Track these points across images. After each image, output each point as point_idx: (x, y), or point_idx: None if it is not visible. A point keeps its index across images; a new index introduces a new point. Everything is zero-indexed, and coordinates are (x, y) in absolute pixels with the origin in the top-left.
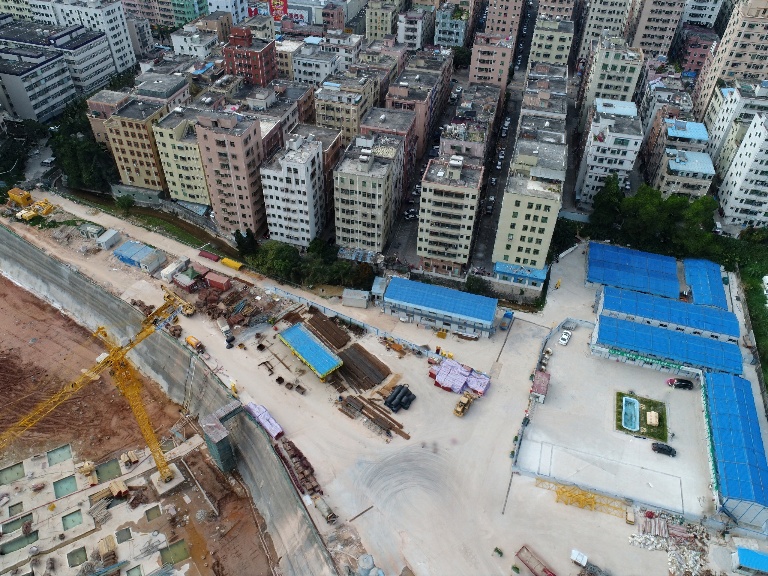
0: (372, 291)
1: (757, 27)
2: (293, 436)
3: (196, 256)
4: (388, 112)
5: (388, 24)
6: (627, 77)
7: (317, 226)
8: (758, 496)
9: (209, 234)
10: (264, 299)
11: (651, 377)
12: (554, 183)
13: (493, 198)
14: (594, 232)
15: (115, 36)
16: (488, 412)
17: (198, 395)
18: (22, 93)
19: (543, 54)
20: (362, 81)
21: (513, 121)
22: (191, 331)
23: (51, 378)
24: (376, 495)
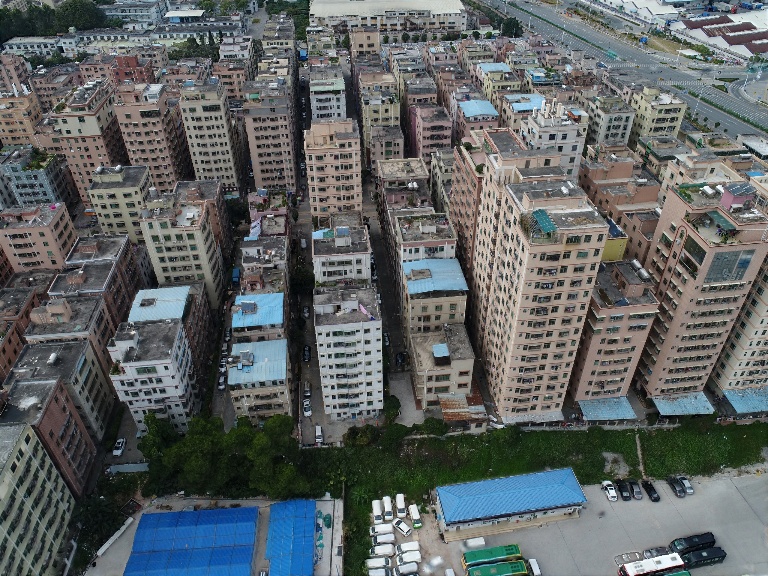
0: None
1: (326, 158)
2: None
3: None
4: None
5: None
6: (189, 245)
7: None
8: None
9: None
10: None
11: None
12: None
13: None
14: (157, 489)
15: None
16: None
17: None
18: None
19: (113, 214)
20: None
21: None
22: None
23: None
24: None
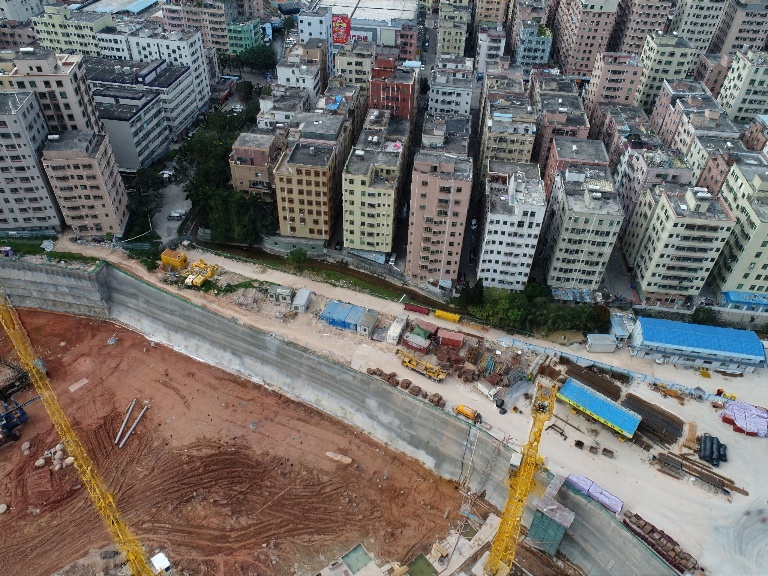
0: (617, 334)
1: None
2: (631, 507)
3: (402, 311)
4: (572, 141)
5: (462, 43)
6: None
7: None
8: None
9: (393, 283)
10: (505, 353)
11: None
12: None
13: None
14: None
15: (196, 69)
16: None
17: (484, 470)
18: (127, 140)
19: (662, 70)
20: (531, 110)
21: None
22: (452, 398)
23: (299, 468)
24: (756, 564)
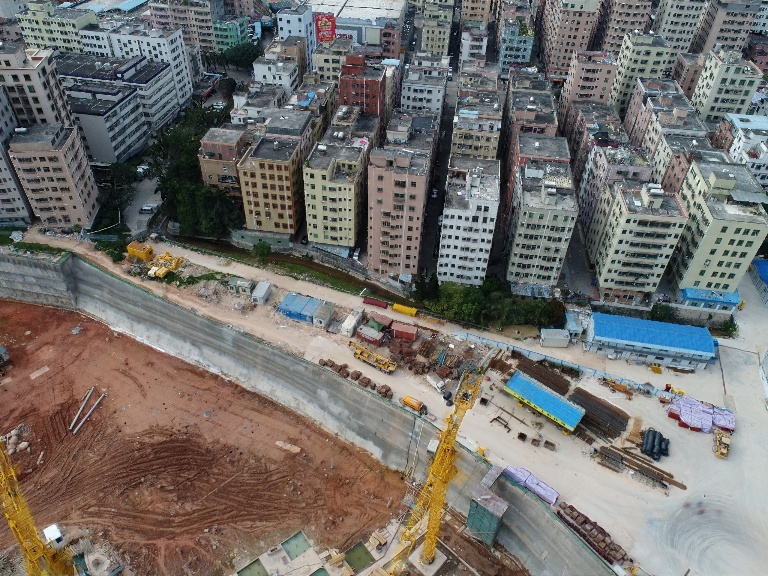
0: (571, 329)
1: None
2: (567, 499)
3: (361, 304)
4: (536, 138)
5: (445, 42)
6: (745, 90)
7: None
8: None
9: (356, 277)
10: (458, 347)
11: None
12: (751, 206)
13: None
14: None
15: (177, 66)
16: (747, 450)
17: (428, 460)
18: (103, 134)
19: (638, 69)
20: (497, 107)
21: None
22: (400, 390)
23: (248, 456)
24: (686, 556)
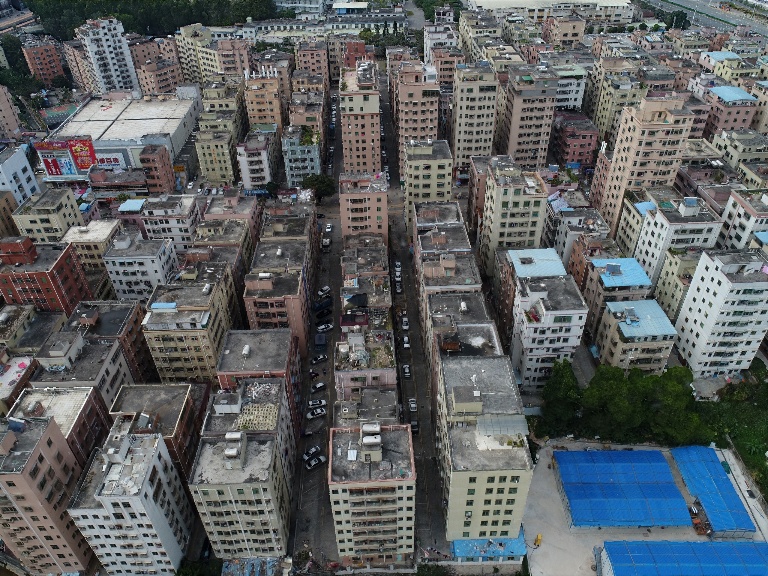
0: None
1: (658, 133)
2: None
3: None
4: (252, 334)
5: (226, 156)
6: (532, 212)
7: (181, 542)
8: None
9: (14, 574)
10: None
11: None
12: None
13: (414, 404)
14: (553, 431)
15: None
16: None
17: None
18: None
19: (422, 185)
20: (206, 290)
21: (404, 265)
22: None
23: None
24: None
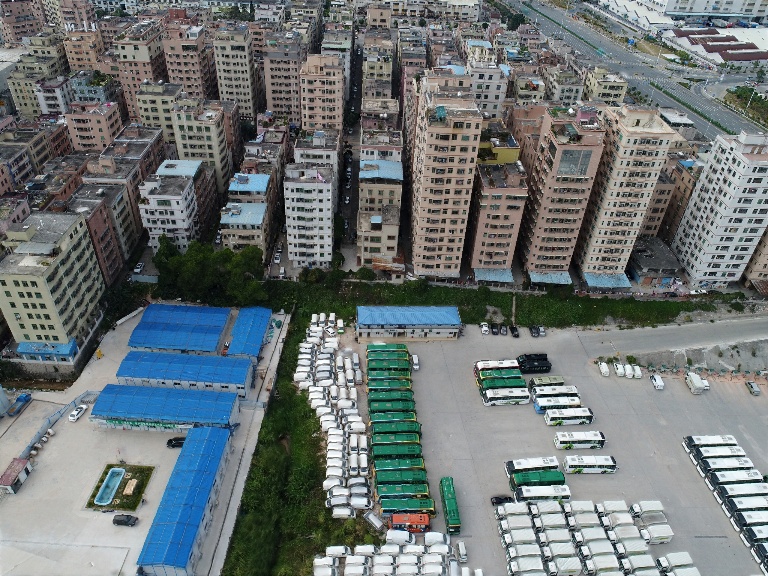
0: None
1: (315, 83)
2: None
3: None
4: None
5: None
6: (206, 136)
7: None
8: (169, 556)
9: None
10: None
11: (153, 440)
12: (52, 256)
13: None
14: (162, 292)
15: None
16: None
17: None
18: None
19: (152, 117)
20: None
21: None
22: None
23: None
24: None
